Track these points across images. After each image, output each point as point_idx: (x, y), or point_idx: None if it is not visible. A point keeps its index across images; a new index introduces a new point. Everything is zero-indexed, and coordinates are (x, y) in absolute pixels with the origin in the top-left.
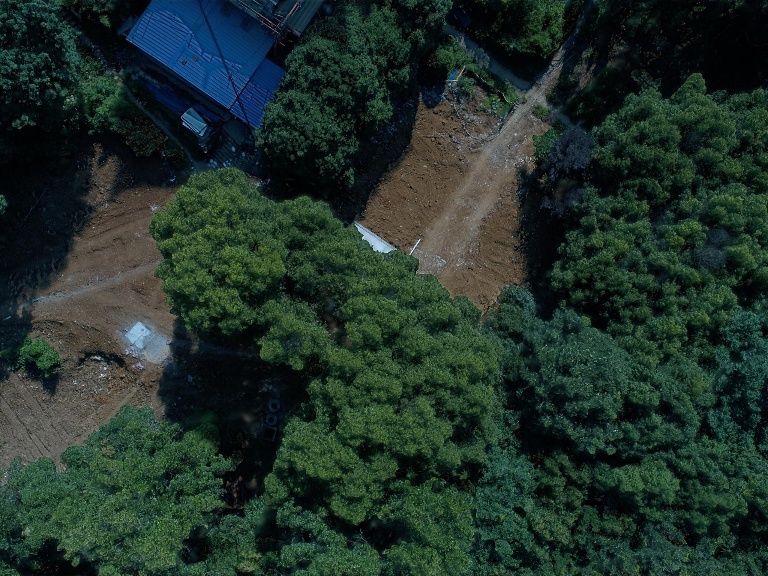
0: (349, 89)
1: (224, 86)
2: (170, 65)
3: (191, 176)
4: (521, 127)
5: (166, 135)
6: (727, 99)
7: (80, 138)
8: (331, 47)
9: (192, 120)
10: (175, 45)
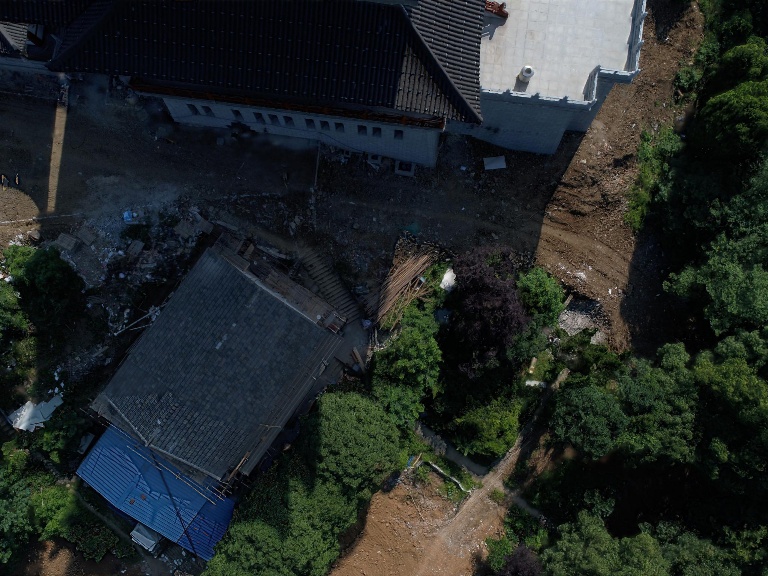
0: (291, 567)
1: (172, 521)
2: (117, 505)
3: None
4: (477, 511)
5: (117, 533)
6: (679, 535)
7: (31, 536)
8: (272, 535)
9: (141, 538)
10: (123, 485)
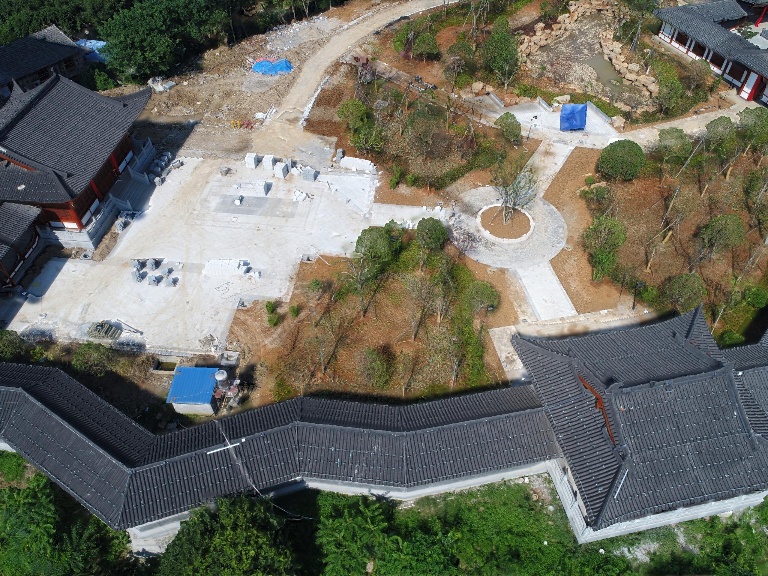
0: None
1: None
2: None
3: (108, 5)
4: None
5: None
6: None
7: None
8: None
9: None
10: None
